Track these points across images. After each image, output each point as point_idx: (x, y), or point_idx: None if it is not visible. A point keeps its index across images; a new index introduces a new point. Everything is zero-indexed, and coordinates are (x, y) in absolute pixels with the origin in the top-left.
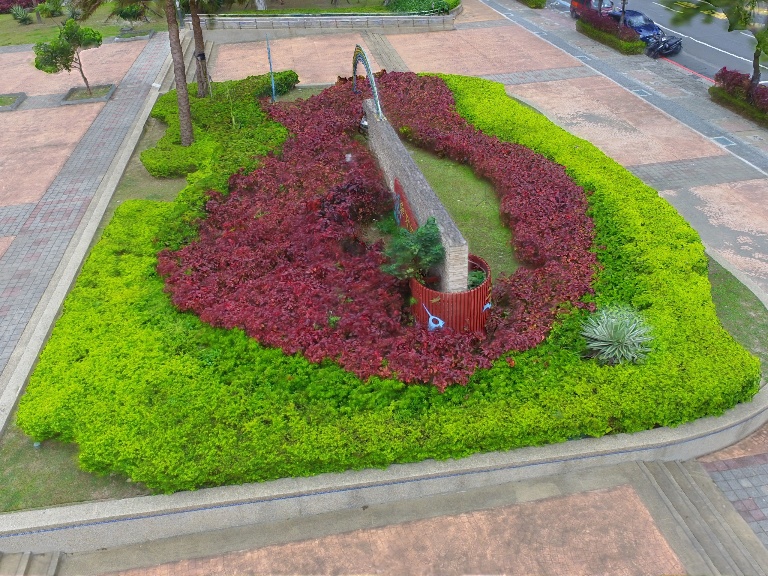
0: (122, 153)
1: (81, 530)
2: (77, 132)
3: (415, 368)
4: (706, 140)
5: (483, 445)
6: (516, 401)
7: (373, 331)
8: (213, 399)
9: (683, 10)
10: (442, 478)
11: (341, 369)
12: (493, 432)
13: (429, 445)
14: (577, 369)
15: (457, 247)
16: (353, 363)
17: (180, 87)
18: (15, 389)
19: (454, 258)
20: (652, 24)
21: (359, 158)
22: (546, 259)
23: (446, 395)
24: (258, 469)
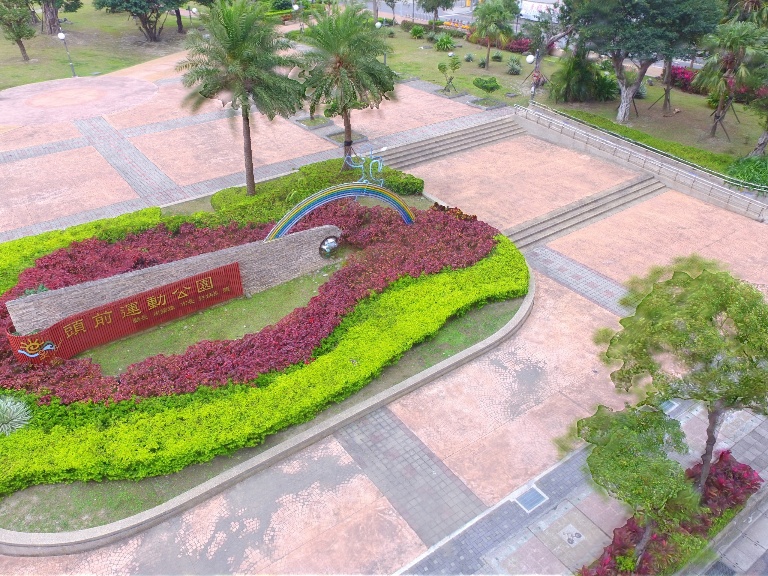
0: None
1: None
2: (282, 159)
3: None
4: (522, 480)
5: None
6: None
7: (7, 321)
8: None
9: None
10: None
11: None
12: None
13: None
14: None
15: None
16: None
17: None
18: None
19: None
20: None
21: None
22: None
23: None
24: None
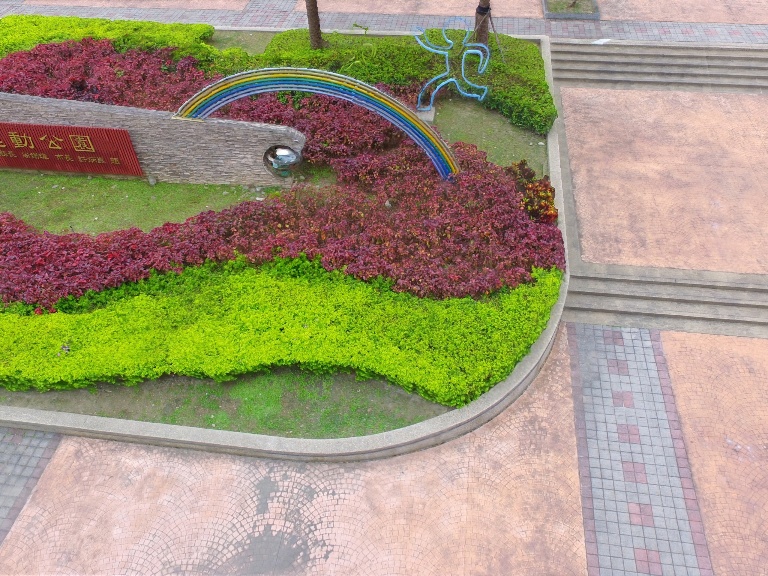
0: None
1: None
2: (446, 11)
3: None
4: None
5: None
6: None
7: None
8: None
9: None
10: None
11: None
12: None
13: None
14: None
15: None
16: None
17: None
18: None
19: None
20: None
21: None
22: None
23: None
24: None
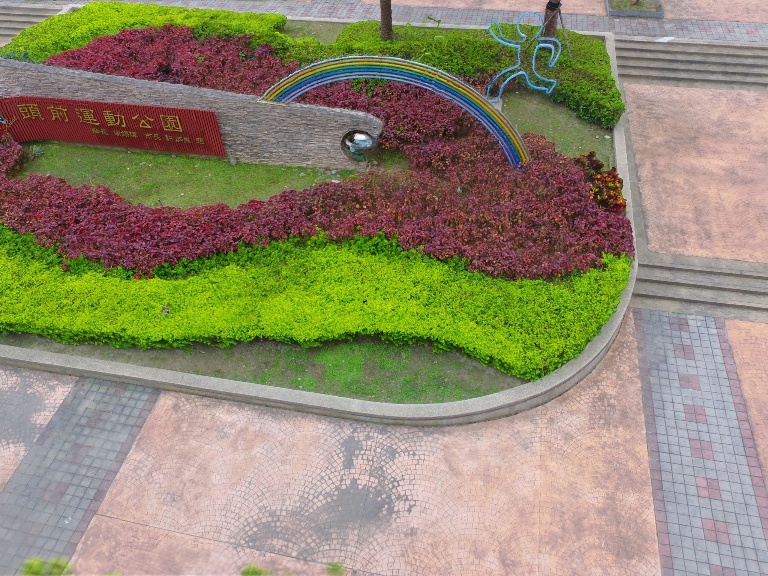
0: None
1: None
2: (510, 7)
3: None
4: None
5: None
6: None
7: None
8: (47, 39)
9: None
10: None
11: None
12: None
13: None
14: None
15: None
16: None
17: None
18: None
19: None
20: None
21: None
22: None
23: None
24: None
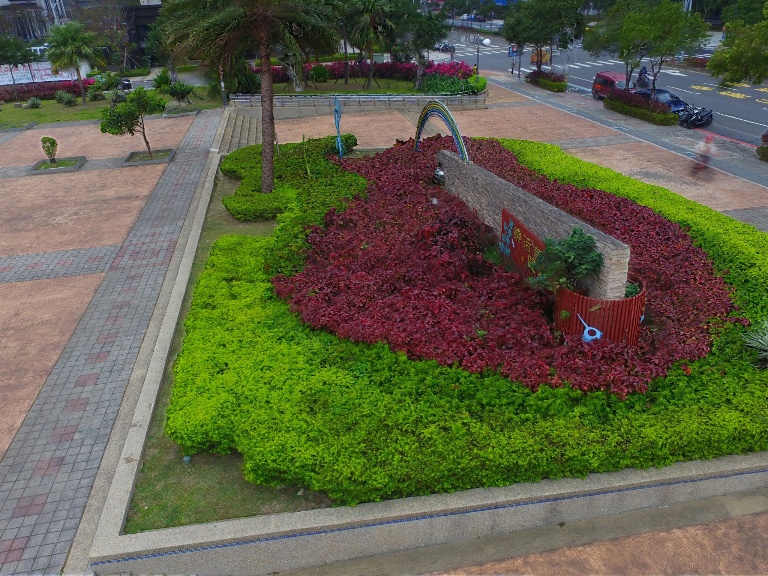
0: (197, 203)
1: (256, 547)
2: (146, 187)
3: (589, 375)
4: None
5: (686, 452)
6: (709, 406)
7: (529, 342)
8: (380, 407)
9: (699, 92)
10: (646, 489)
11: (506, 378)
12: (699, 435)
13: (632, 449)
14: (758, 377)
15: (619, 250)
16: (518, 372)
17: (267, 134)
18: (148, 406)
19: (615, 262)
20: (679, 100)
21: (447, 200)
22: (672, 283)
23: (628, 402)
24: (451, 476)
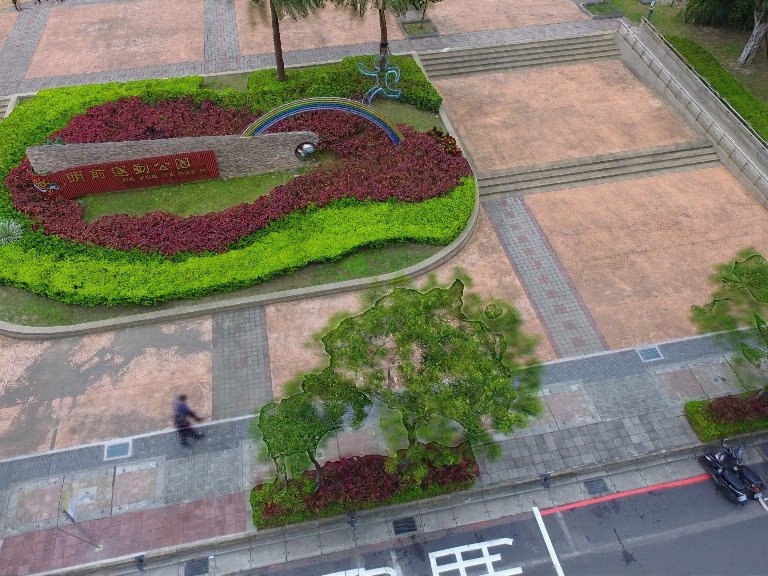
0: None
1: None
2: (344, 42)
3: None
4: None
5: None
6: None
7: None
8: None
9: None
10: None
11: None
12: None
13: None
14: None
15: None
16: None
17: None
18: None
19: None
20: None
21: None
22: None
23: None
24: None
